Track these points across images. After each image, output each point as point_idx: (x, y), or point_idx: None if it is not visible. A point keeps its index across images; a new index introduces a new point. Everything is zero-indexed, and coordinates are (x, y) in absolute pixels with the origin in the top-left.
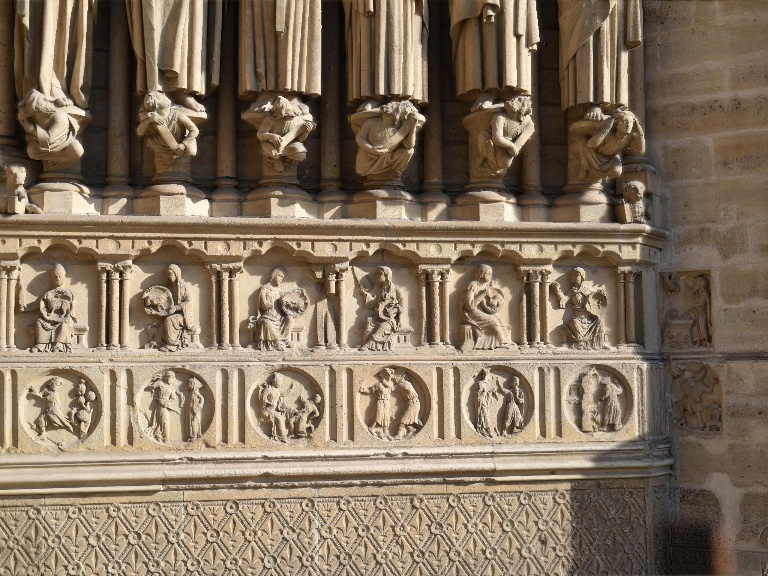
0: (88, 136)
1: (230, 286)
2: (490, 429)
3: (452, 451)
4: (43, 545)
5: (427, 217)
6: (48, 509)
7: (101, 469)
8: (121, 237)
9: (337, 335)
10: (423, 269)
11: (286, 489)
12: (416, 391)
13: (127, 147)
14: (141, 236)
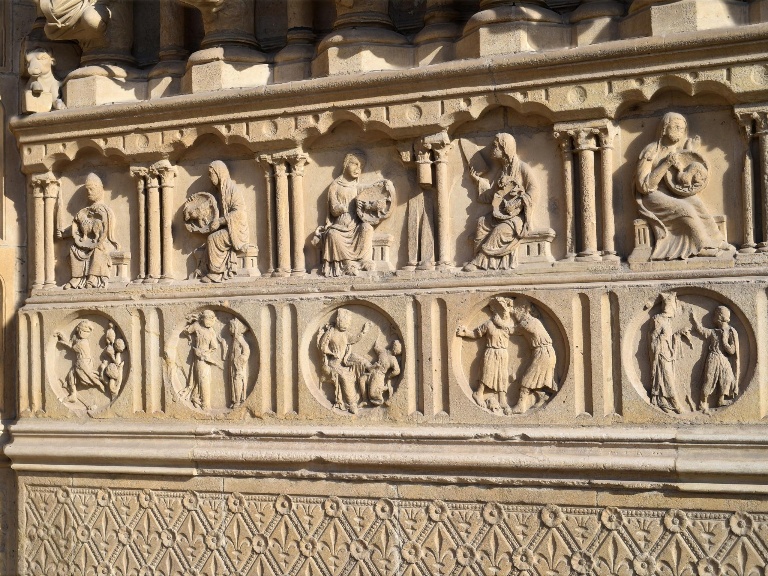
0: (148, 3)
1: (290, 185)
2: (675, 399)
3: (602, 435)
4: (72, 537)
5: (577, 45)
6: (77, 491)
7: (127, 442)
8: (148, 129)
9: (436, 248)
10: (561, 131)
11: (353, 483)
12: (550, 334)
13: (180, 8)
14: (169, 125)
